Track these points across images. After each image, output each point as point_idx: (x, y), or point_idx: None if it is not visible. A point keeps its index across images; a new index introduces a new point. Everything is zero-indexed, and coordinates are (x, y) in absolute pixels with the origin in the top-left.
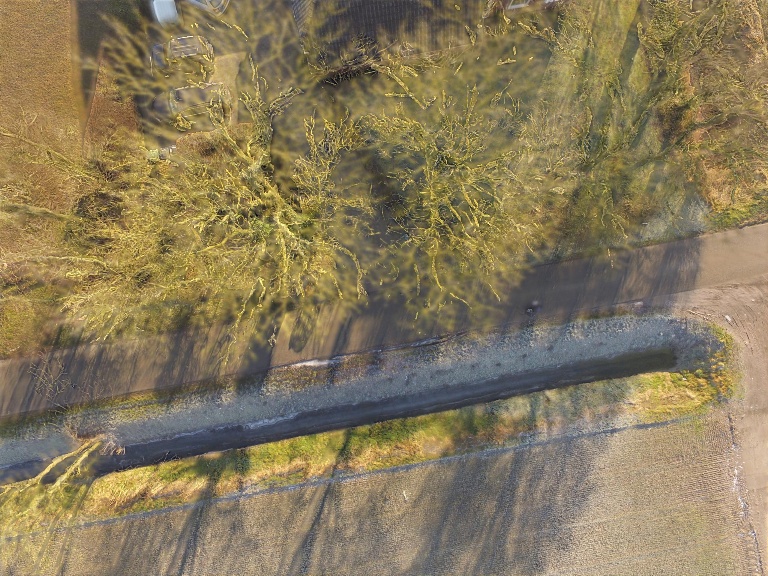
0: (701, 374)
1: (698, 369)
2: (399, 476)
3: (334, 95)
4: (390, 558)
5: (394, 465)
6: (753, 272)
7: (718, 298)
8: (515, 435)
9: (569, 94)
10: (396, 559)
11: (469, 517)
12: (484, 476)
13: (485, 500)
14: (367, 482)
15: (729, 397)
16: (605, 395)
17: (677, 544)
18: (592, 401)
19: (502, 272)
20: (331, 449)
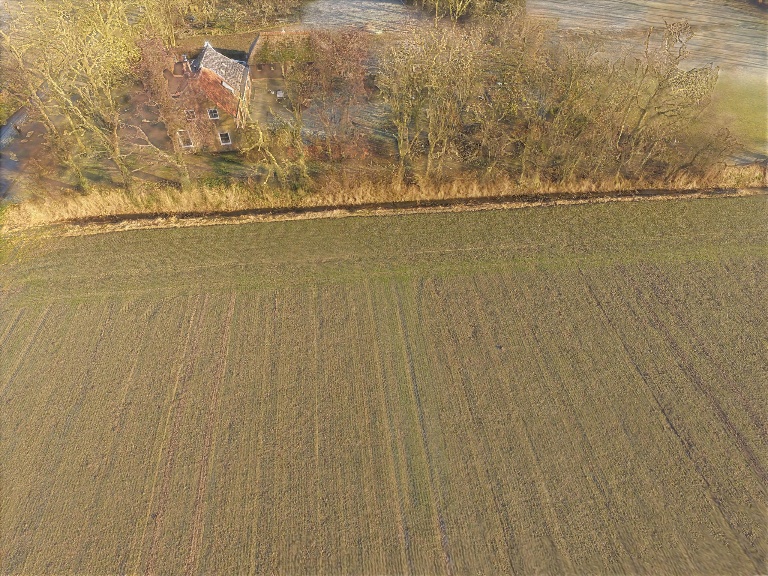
0: None
1: None
2: None
3: None
4: None
5: None
6: None
7: None
8: None
9: None
10: None
11: None
12: None
13: None
14: None
15: None
16: None
17: None
18: None
19: None
20: None
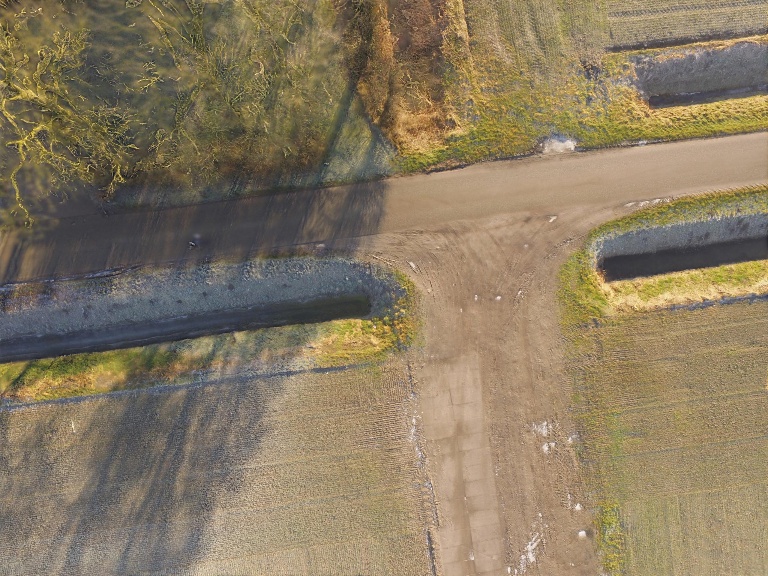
0: (387, 321)
1: (385, 316)
2: (68, 408)
3: (5, 17)
4: (56, 490)
5: (62, 396)
6: (439, 219)
7: (402, 244)
8: (188, 372)
9: (248, 27)
10: (62, 491)
11: (138, 453)
12: (155, 412)
13: (155, 437)
14: (36, 412)
15: (408, 345)
16: (290, 338)
17: (350, 491)
18: (275, 343)
19: (178, 206)
20: (6, 378)
